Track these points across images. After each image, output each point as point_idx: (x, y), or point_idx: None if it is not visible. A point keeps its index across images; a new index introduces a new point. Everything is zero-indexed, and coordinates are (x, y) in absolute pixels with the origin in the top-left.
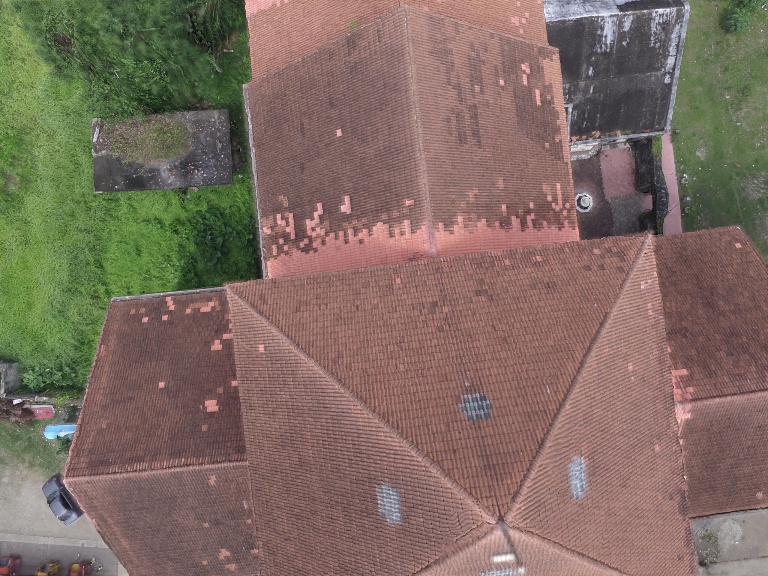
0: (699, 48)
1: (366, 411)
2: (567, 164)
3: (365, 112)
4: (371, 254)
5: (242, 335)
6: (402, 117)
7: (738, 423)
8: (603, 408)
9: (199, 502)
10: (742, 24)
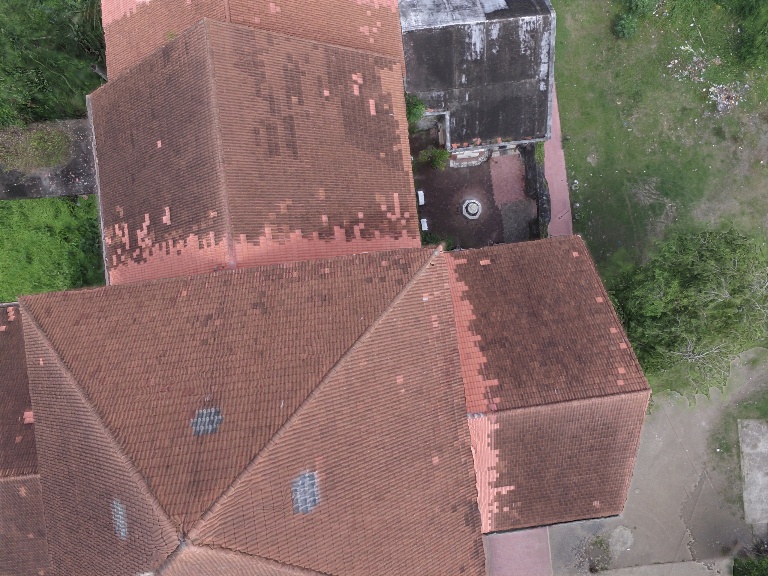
0: (590, 54)
1: (100, 426)
2: (408, 173)
3: (178, 124)
4: (186, 265)
5: (30, 348)
6: (205, 129)
7: (551, 433)
8: (354, 422)
9: (16, 514)
10: (629, 30)
